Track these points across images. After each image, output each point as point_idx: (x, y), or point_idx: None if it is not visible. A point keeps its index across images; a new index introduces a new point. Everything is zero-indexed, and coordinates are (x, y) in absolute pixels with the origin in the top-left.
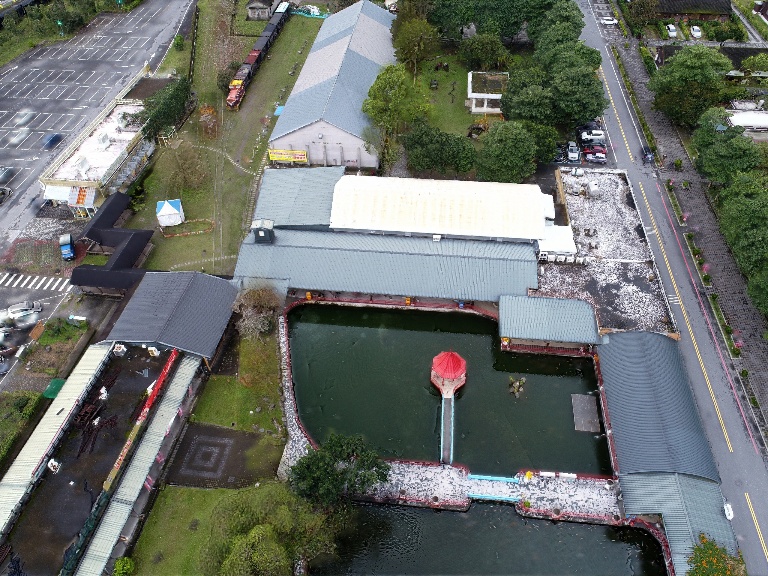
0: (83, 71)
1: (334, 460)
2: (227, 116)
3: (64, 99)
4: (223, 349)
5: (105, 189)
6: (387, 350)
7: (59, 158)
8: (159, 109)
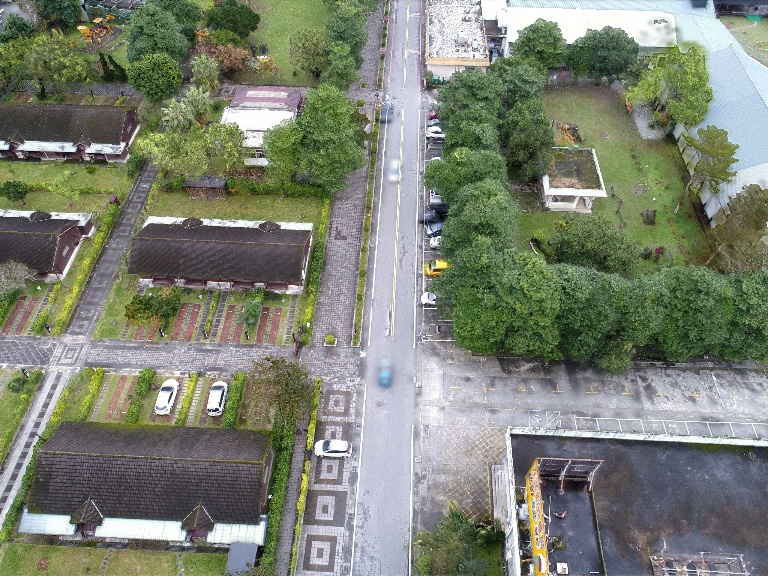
0: None
1: None
2: None
3: None
4: None
5: None
6: None
7: None
8: None
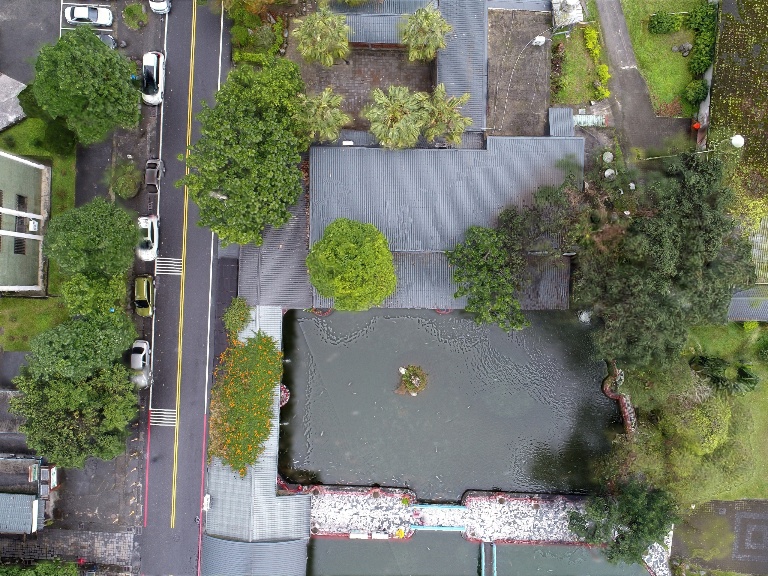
0: None
1: (638, 531)
2: None
3: None
4: None
5: None
6: None
7: None
8: None
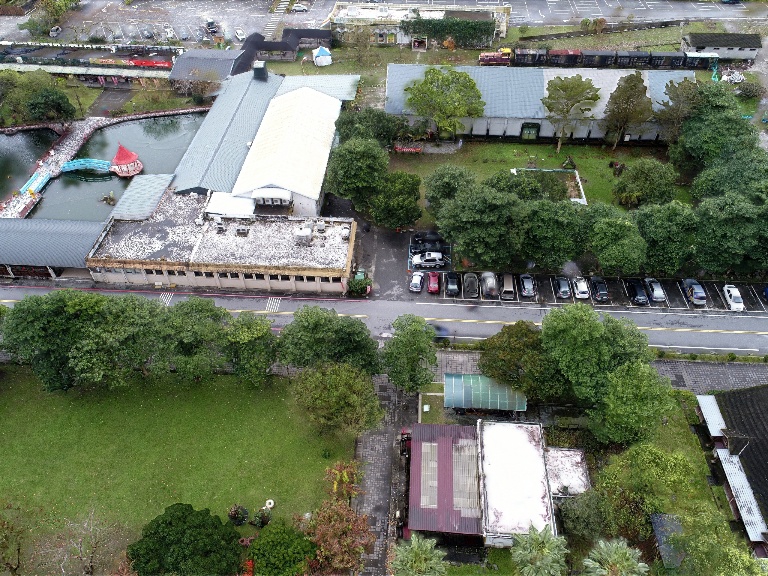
0: (525, 2)
1: None
2: (469, 64)
3: (477, 4)
4: (189, 93)
5: (335, 26)
6: (169, 151)
7: (360, 3)
8: (432, 21)
